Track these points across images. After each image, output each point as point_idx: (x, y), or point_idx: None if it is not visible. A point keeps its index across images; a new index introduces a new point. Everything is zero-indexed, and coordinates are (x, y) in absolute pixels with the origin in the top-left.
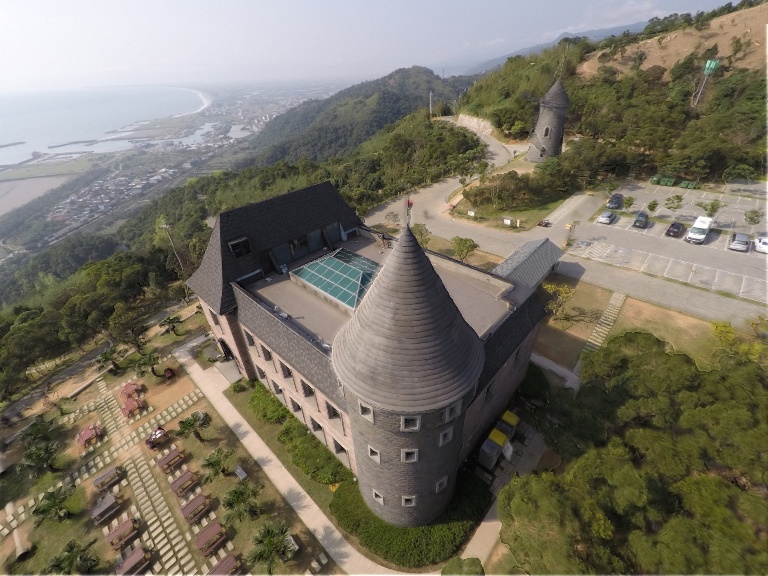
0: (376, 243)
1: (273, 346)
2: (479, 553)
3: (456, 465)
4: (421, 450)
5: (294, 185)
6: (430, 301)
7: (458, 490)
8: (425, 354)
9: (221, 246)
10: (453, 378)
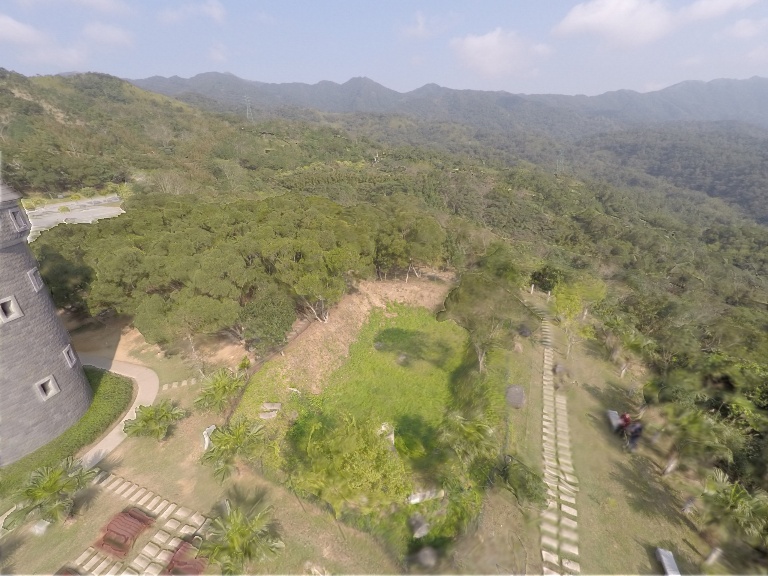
0: None
1: None
2: (133, 369)
3: None
4: None
5: None
6: None
7: None
8: None
9: None
10: None
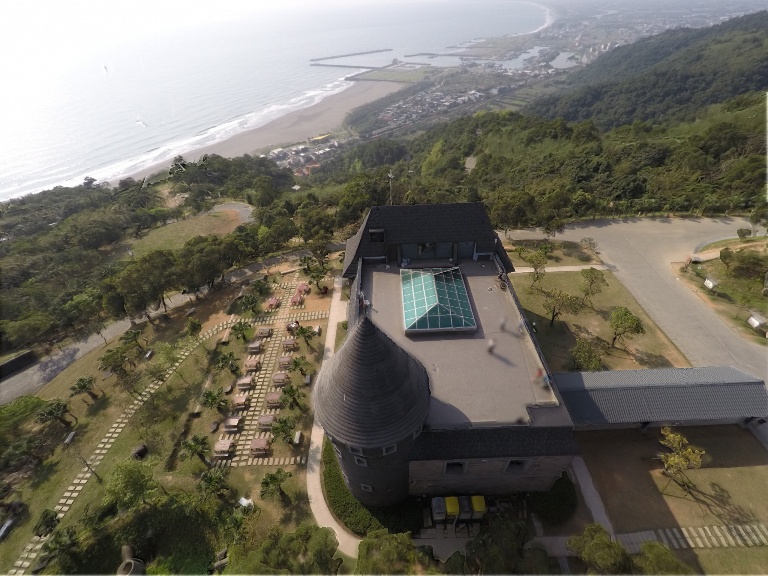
0: (497, 277)
1: (349, 319)
2: None
3: (387, 487)
4: (343, 454)
5: (557, 151)
6: (361, 373)
7: (399, 506)
8: (345, 402)
9: (364, 230)
10: (358, 431)
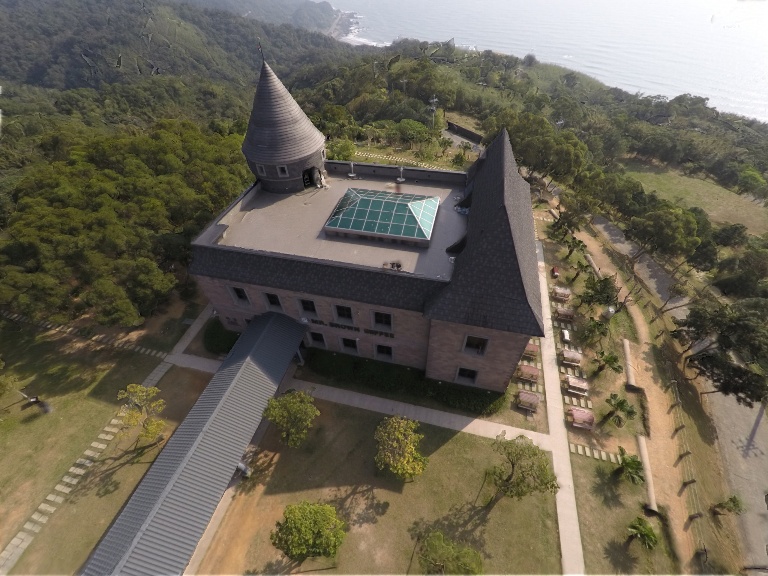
0: None
1: None
2: None
3: None
4: None
5: None
6: None
7: None
8: None
9: None
10: None
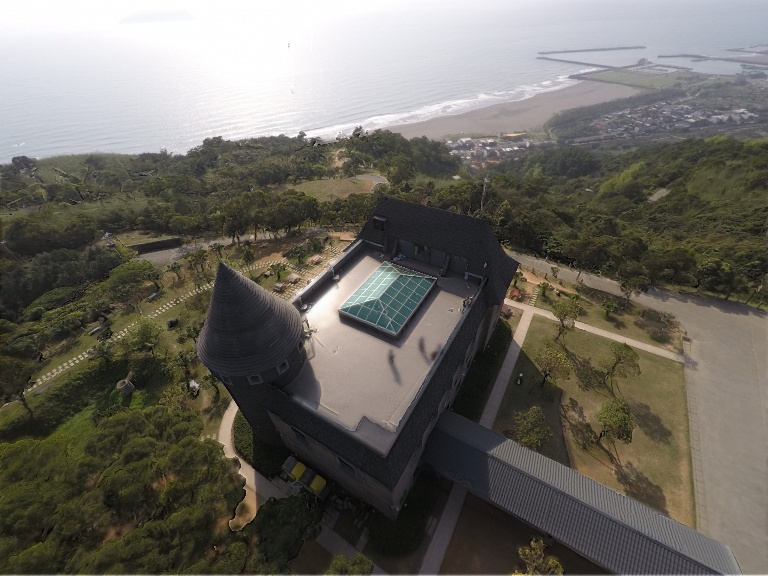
0: None
1: None
2: None
3: (255, 422)
4: None
5: None
6: None
7: (273, 449)
8: None
9: None
10: (206, 351)
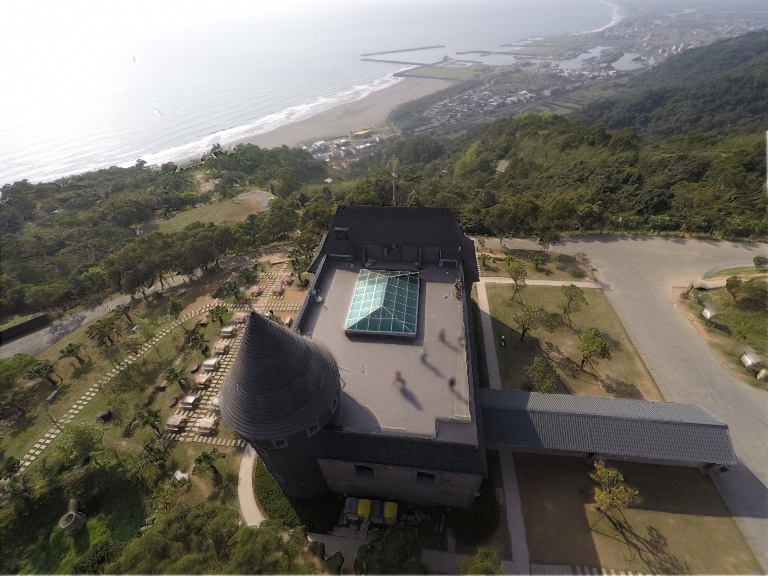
0: None
1: None
2: None
3: (299, 480)
4: None
5: (591, 158)
6: (250, 366)
7: (318, 500)
8: (238, 392)
9: None
10: (247, 421)
